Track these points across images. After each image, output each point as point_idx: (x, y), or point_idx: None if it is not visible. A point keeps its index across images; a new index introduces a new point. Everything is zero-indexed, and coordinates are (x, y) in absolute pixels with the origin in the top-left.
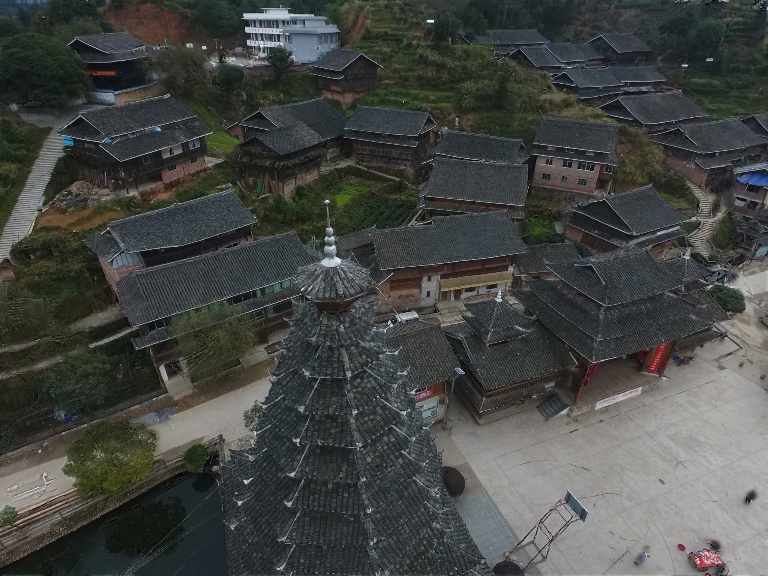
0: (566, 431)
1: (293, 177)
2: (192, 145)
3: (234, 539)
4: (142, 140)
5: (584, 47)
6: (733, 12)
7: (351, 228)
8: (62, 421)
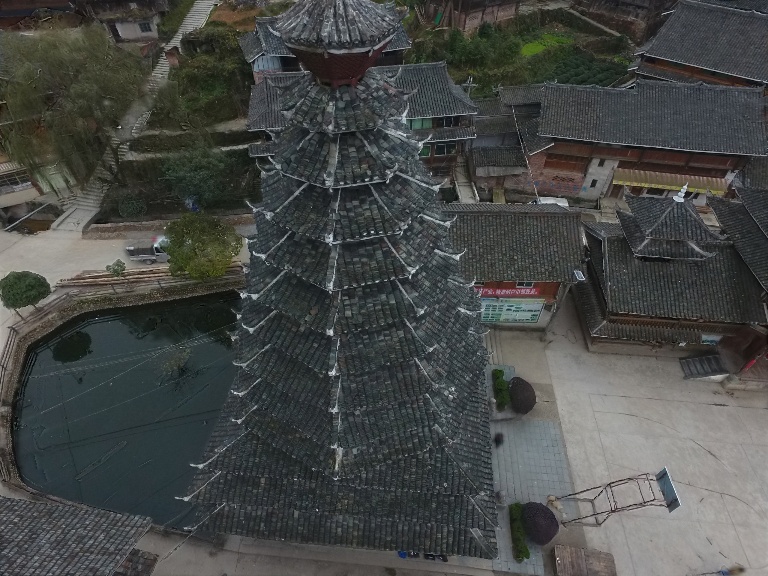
0: (708, 401)
1: (481, 9)
2: None
3: None
4: None
5: None
6: None
7: None
8: (190, 209)
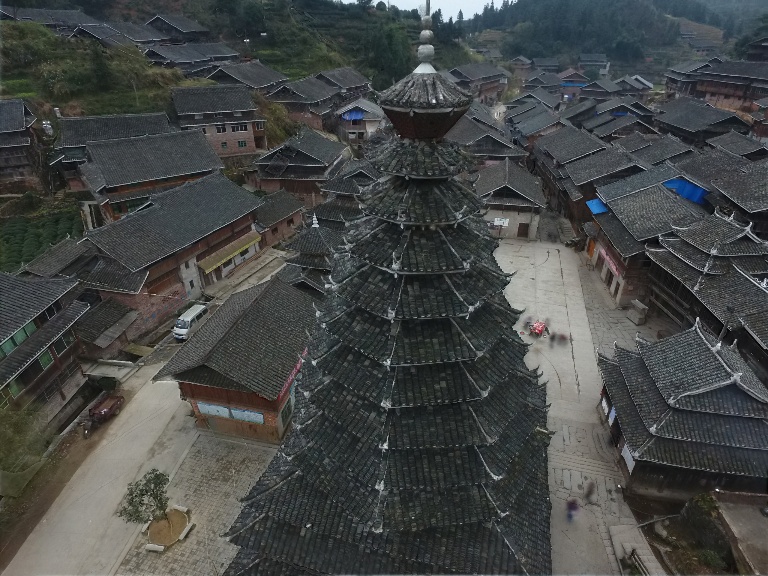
0: None
1: None
2: None
3: (351, 571)
4: None
5: (145, 28)
6: None
7: (11, 263)
8: None
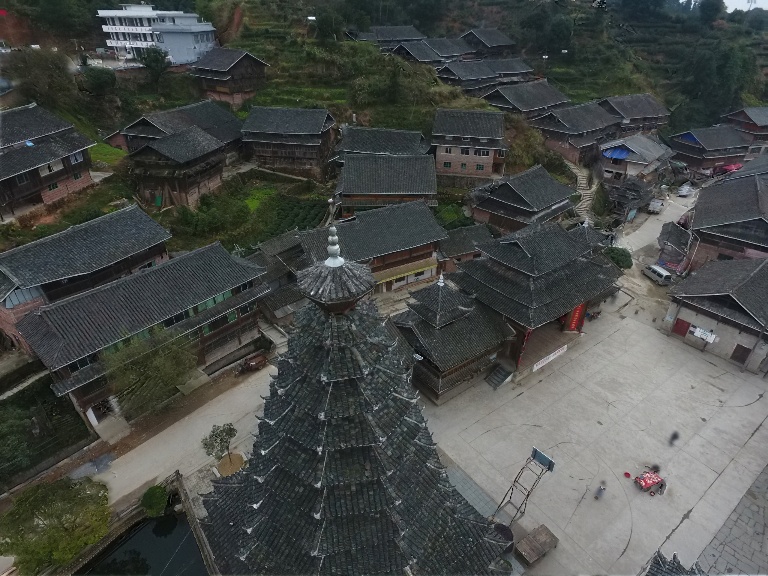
0: (514, 396)
1: (196, 186)
2: (74, 159)
3: (239, 572)
4: (12, 157)
5: (458, 42)
6: (577, 9)
7: (269, 233)
8: None
